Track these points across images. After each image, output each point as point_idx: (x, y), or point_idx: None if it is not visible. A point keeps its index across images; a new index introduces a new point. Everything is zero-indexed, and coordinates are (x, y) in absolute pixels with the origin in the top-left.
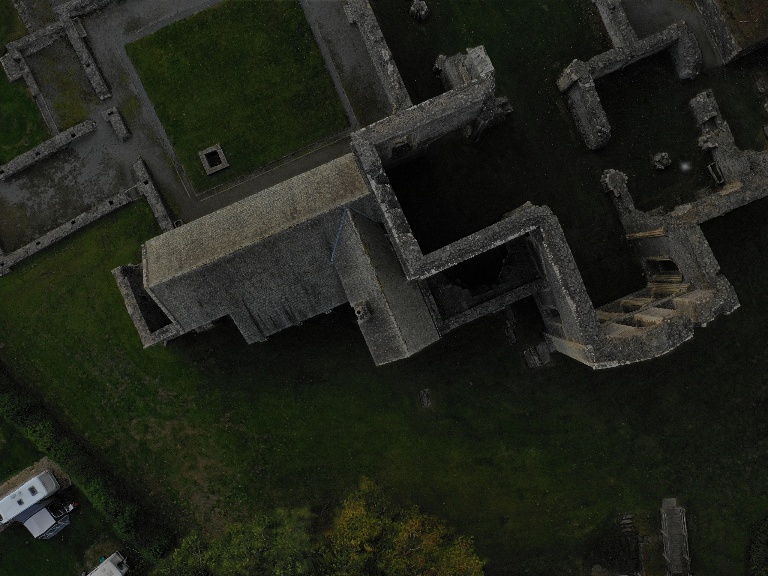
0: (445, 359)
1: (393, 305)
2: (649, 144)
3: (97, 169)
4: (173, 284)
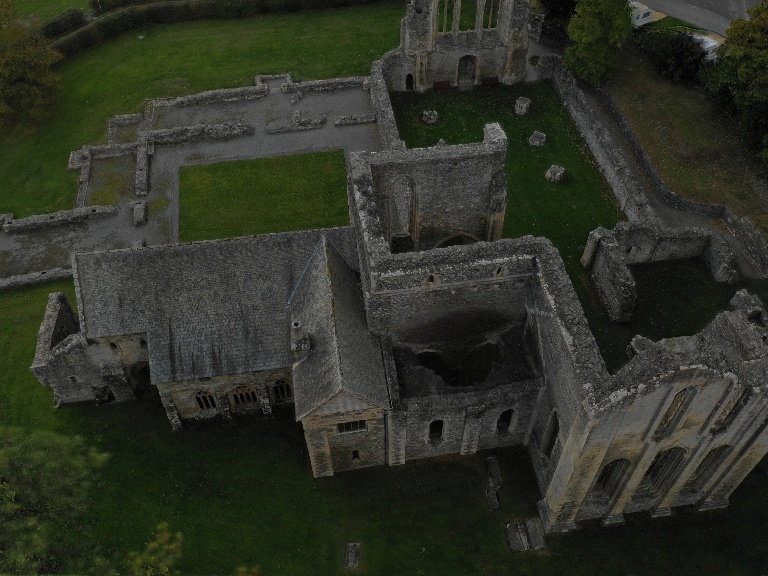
0: (395, 507)
1: (341, 335)
2: (684, 329)
3: (97, 241)
4: (103, 261)
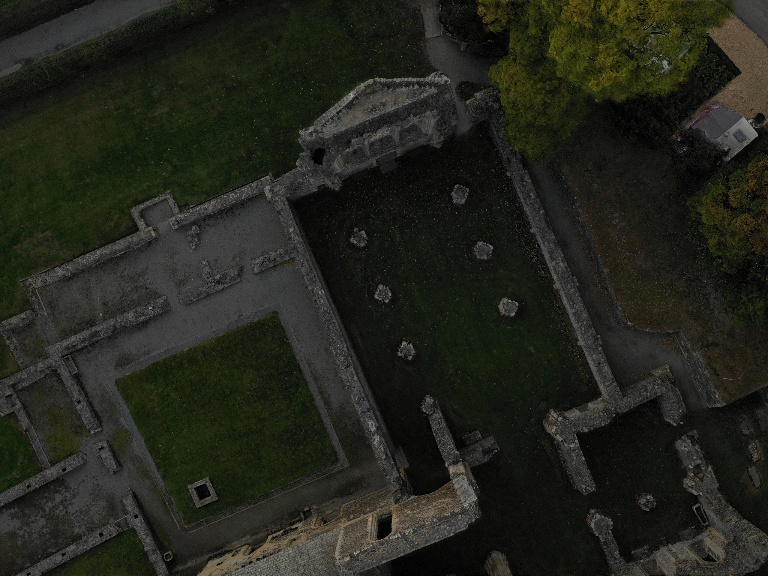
0: None
1: None
2: (634, 484)
3: (87, 500)
4: None
